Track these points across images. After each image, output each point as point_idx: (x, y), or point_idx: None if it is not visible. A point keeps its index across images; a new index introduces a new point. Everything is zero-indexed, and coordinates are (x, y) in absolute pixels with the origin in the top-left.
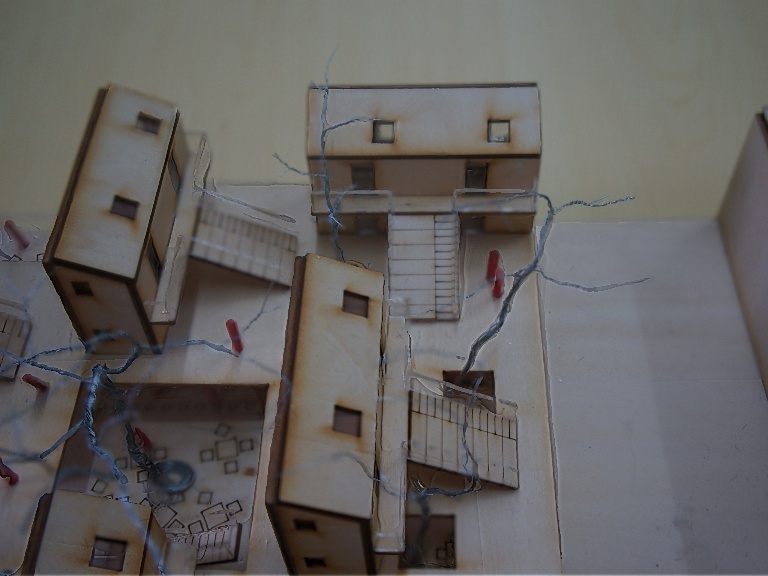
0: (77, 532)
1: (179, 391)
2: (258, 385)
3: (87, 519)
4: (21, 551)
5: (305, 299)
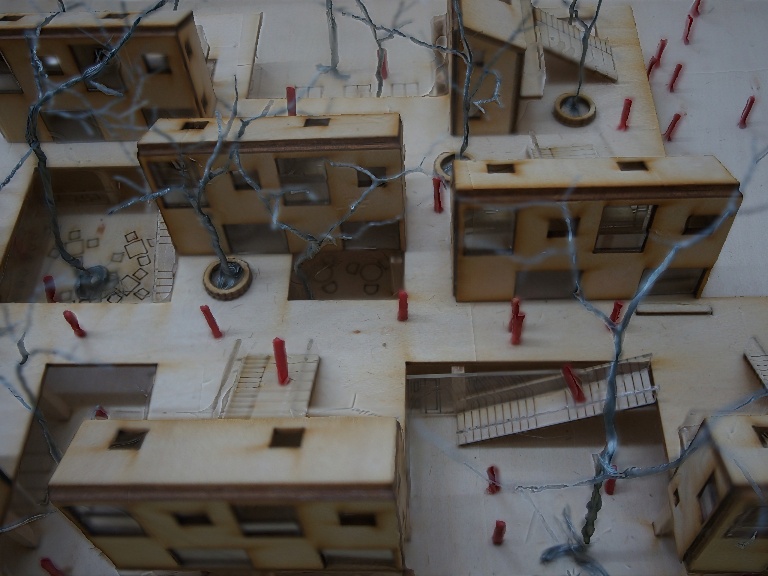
0: (175, 135)
1: (3, 287)
2: (33, 176)
3: (165, 133)
4: (154, 312)
5: (0, 28)
